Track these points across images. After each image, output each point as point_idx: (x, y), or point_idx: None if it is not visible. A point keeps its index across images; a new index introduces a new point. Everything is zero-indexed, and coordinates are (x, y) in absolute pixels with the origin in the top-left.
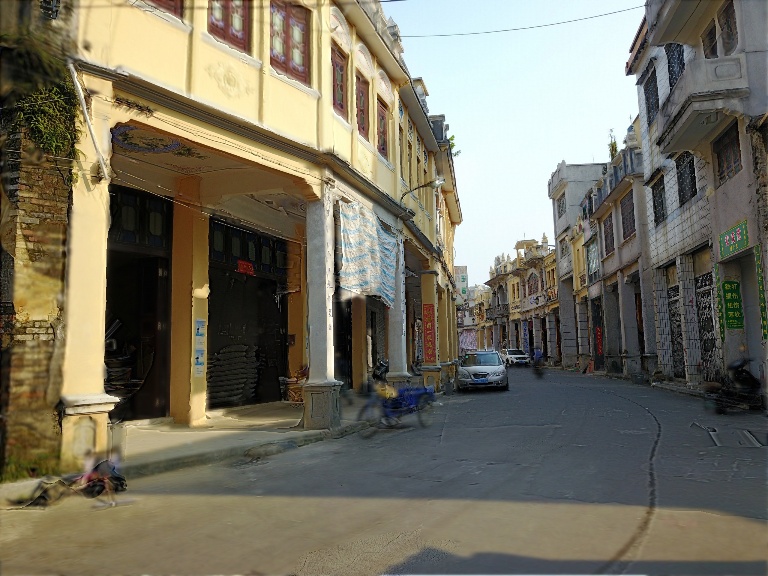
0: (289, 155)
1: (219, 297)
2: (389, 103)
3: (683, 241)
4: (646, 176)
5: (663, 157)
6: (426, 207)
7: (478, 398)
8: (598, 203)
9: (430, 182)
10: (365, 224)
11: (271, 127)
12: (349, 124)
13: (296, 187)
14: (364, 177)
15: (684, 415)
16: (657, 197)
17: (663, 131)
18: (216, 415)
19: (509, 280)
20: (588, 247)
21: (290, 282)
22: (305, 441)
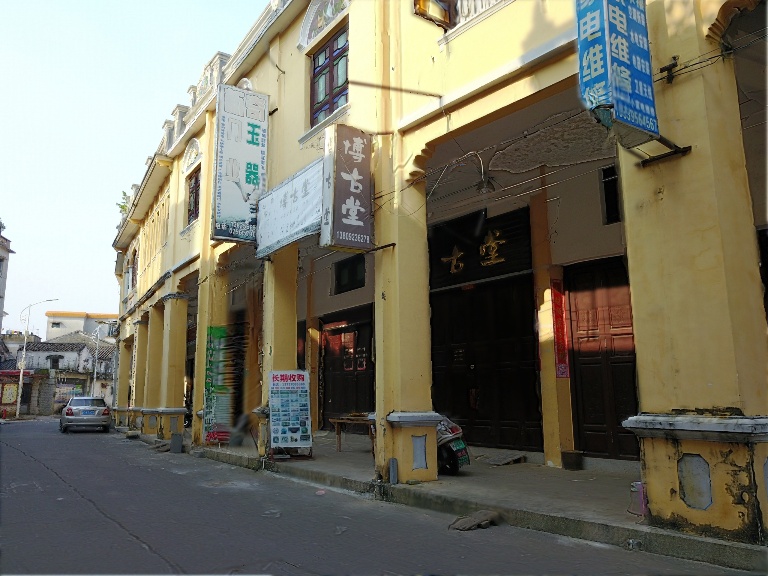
0: None
1: None
2: None
3: None
4: None
5: None
6: None
7: None
8: None
9: None
10: None
11: None
12: None
13: None
14: None
15: None
16: None
17: None
18: None
19: None
20: None
21: None
22: None
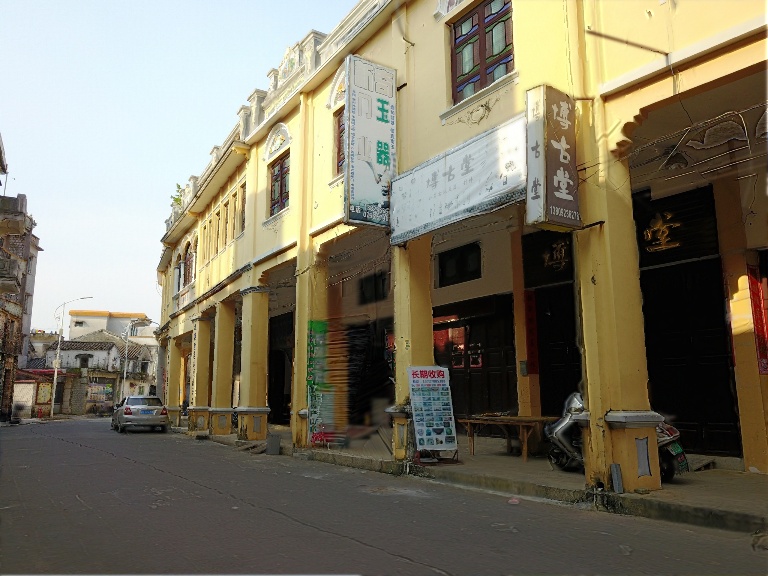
0: None
1: None
2: None
3: None
4: None
5: None
6: None
7: None
8: None
9: None
10: None
11: None
12: None
13: None
14: None
15: None
16: None
17: None
18: None
19: None
20: None
21: None
22: None
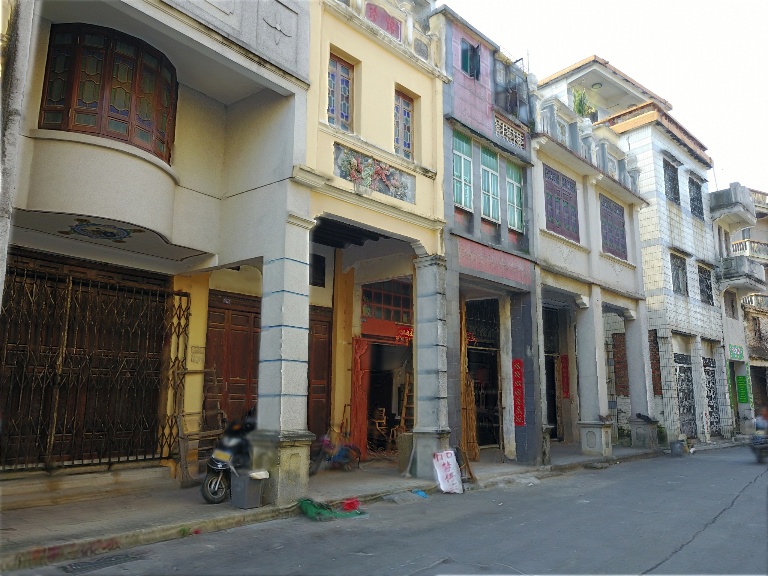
0: None
1: None
2: None
3: (704, 328)
4: None
5: None
6: None
7: None
8: None
9: None
10: None
11: None
12: None
13: None
14: None
15: None
16: (674, 267)
17: None
18: None
19: None
20: (455, 134)
21: None
22: None
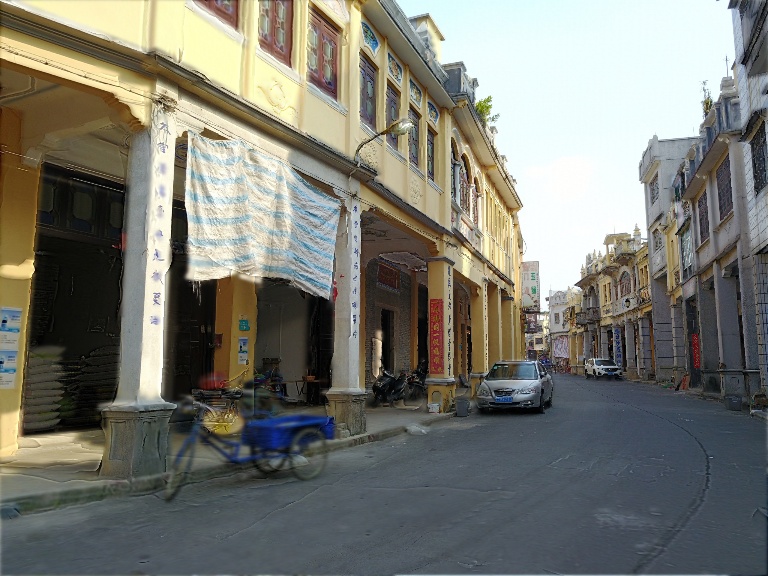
0: (76, 53)
1: (89, 281)
2: (341, 23)
3: None
4: (744, 129)
5: (763, 96)
6: (436, 177)
7: (491, 423)
8: (690, 178)
9: (392, 126)
10: (259, 174)
11: (33, 6)
12: (237, 32)
13: (112, 110)
14: (249, 104)
15: (765, 478)
16: (757, 155)
17: (750, 40)
18: (58, 441)
19: (600, 280)
20: (682, 236)
21: (217, 266)
22: (61, 502)
